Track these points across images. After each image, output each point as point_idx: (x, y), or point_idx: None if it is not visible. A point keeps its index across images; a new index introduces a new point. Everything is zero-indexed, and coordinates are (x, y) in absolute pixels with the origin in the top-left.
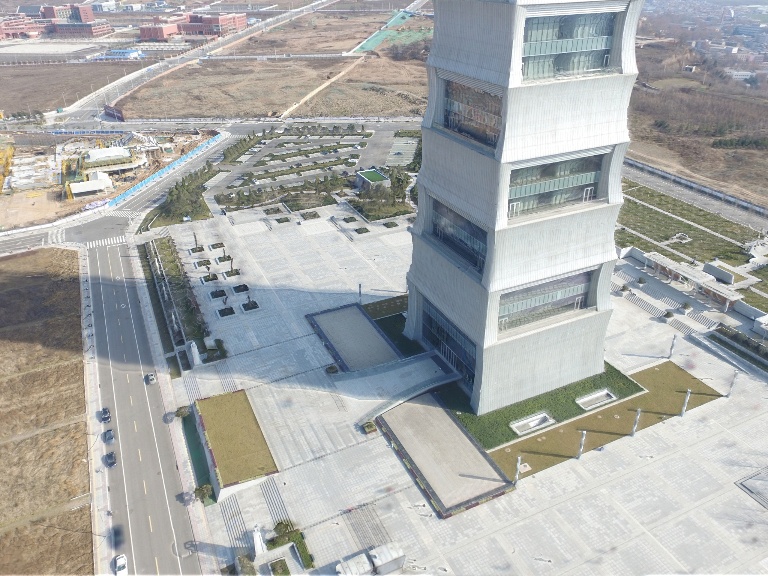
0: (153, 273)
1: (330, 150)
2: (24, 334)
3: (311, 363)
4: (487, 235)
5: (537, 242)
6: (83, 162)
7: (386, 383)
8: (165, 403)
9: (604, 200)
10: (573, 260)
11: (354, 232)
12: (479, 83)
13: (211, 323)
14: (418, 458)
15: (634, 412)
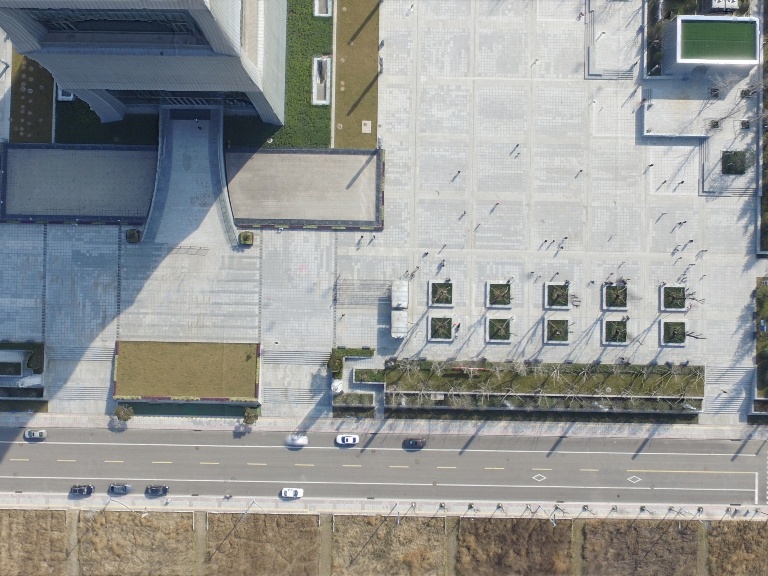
0: None
1: None
2: None
3: (106, 254)
4: (189, 14)
5: None
6: None
7: (188, 190)
8: (90, 427)
9: None
10: None
11: None
12: None
13: None
14: (309, 214)
15: None
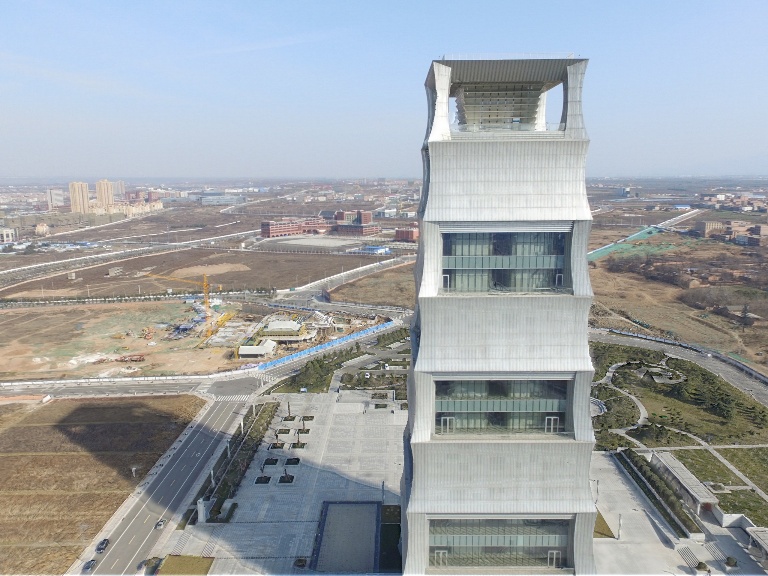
0: None
1: None
2: (114, 460)
3: (290, 550)
4: None
5: (473, 467)
6: (261, 330)
7: None
8: (152, 550)
9: (569, 434)
10: (526, 499)
11: None
12: None
13: (244, 487)
14: None
15: None
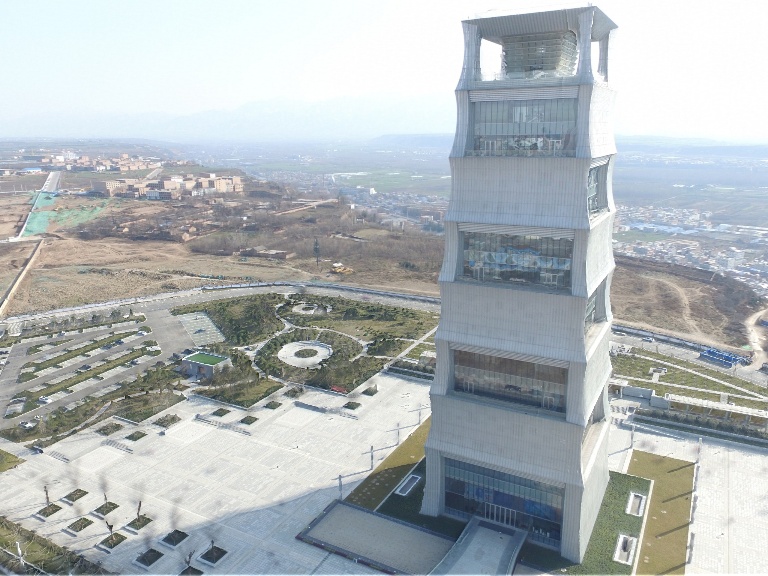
0: (1, 569)
1: (110, 343)
2: None
3: None
4: (568, 371)
5: None
6: None
7: (471, 573)
8: None
9: (605, 319)
10: (602, 378)
11: (241, 424)
12: (535, 230)
13: None
14: None
15: (668, 502)
